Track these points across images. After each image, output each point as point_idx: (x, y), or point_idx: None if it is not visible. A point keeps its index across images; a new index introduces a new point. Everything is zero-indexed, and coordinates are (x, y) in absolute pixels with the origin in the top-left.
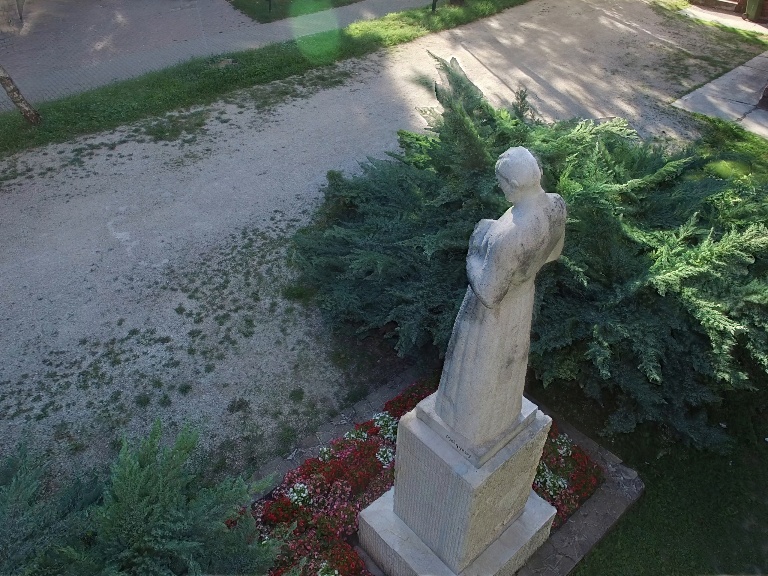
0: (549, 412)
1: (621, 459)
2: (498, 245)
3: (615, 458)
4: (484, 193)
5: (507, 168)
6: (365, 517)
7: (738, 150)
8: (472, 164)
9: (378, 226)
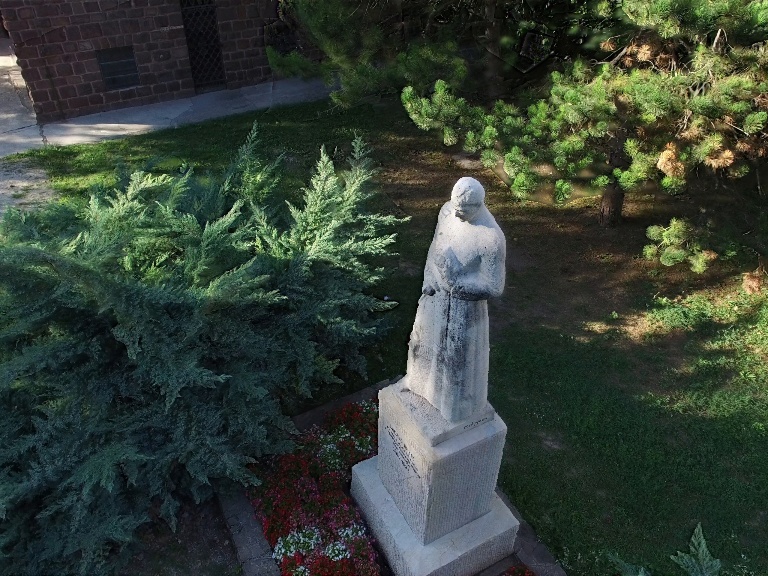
0: (326, 407)
1: (387, 379)
2: (501, 248)
3: (385, 382)
4: (181, 299)
5: (476, 196)
6: (423, 575)
7: (87, 163)
8: (112, 294)
9: (22, 453)
